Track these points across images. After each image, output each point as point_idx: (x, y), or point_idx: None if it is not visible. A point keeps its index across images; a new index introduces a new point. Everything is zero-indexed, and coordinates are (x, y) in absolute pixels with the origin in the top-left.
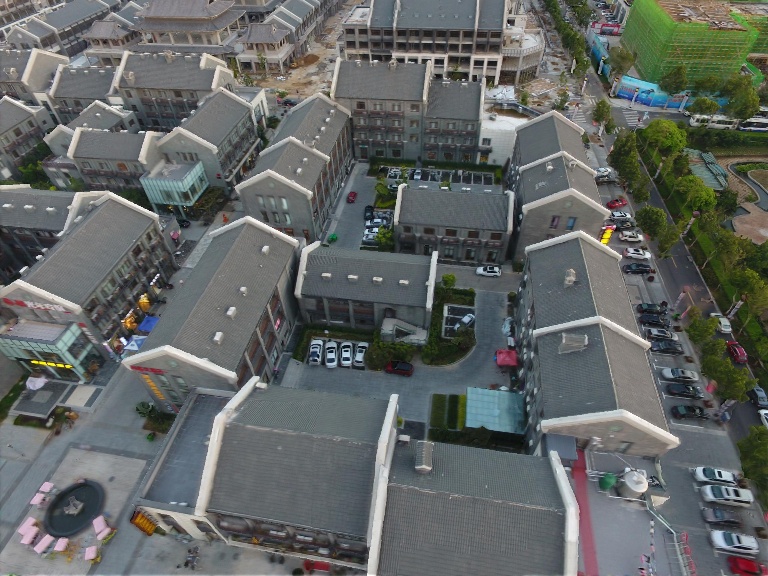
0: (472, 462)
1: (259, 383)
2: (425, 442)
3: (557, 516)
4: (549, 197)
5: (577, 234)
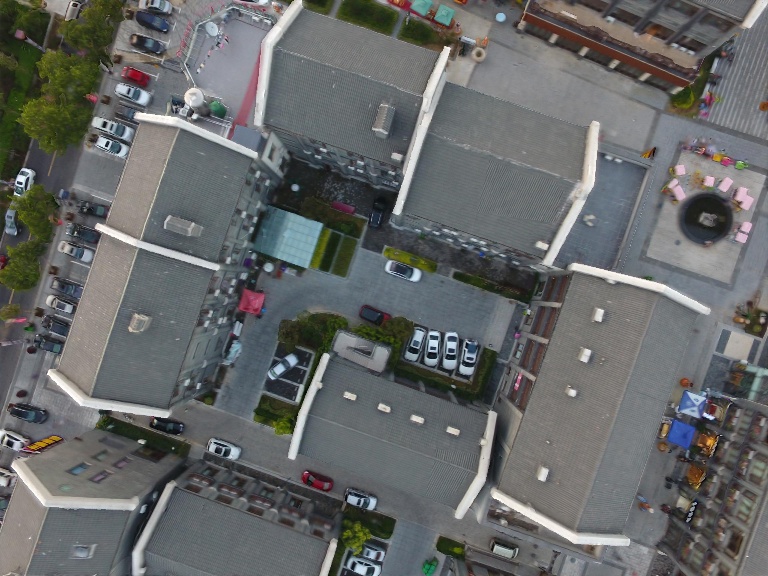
0: (338, 122)
1: (545, 248)
2: (381, 128)
3: (283, 47)
4: (88, 505)
5: (90, 401)
